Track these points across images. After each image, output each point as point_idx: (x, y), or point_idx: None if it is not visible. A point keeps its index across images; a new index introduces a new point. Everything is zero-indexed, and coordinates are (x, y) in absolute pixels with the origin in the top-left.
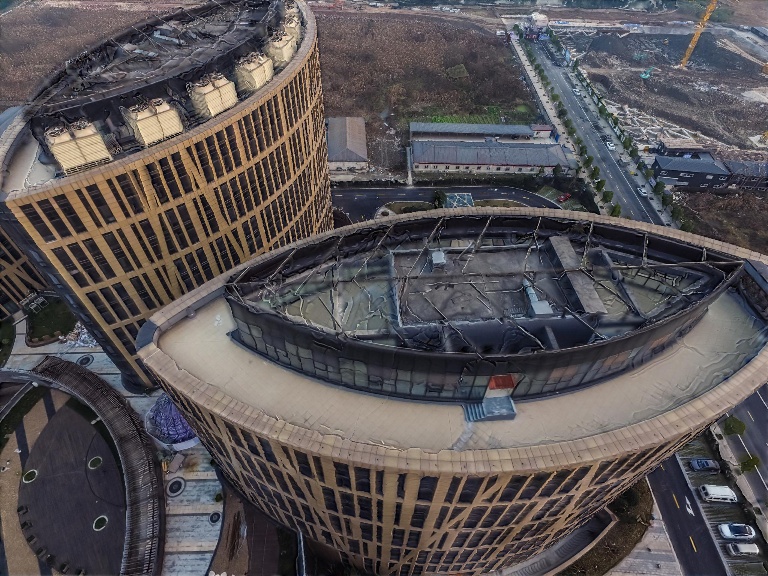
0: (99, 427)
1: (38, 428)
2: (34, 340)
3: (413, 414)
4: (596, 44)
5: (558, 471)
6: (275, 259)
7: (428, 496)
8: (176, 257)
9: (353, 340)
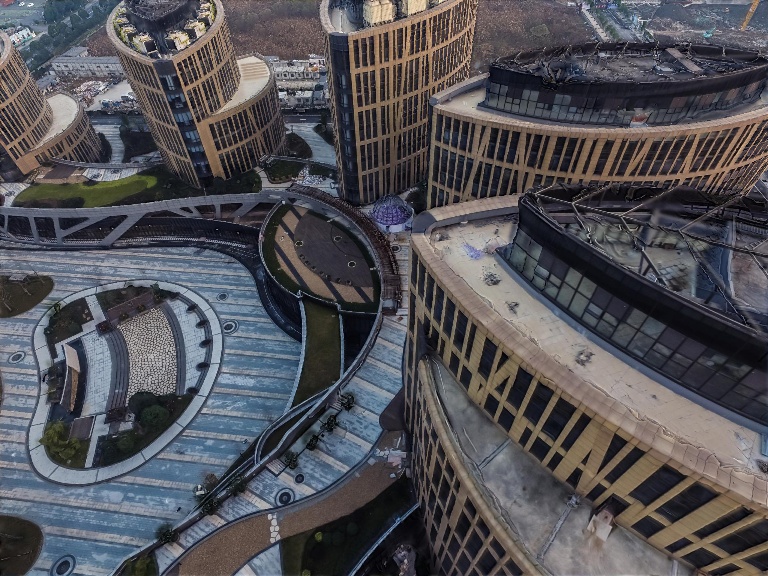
0: (333, 223)
1: (294, 223)
2: (276, 179)
3: None
4: (661, 12)
5: (677, 141)
6: (511, 55)
7: (601, 168)
8: (405, 97)
9: (565, 84)
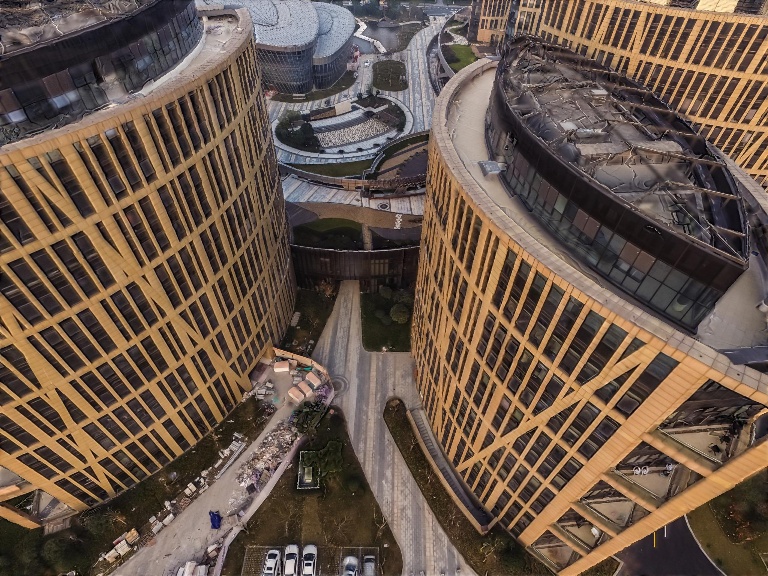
0: None
1: None
2: None
3: (477, 143)
4: None
5: None
6: None
7: None
8: None
9: None
